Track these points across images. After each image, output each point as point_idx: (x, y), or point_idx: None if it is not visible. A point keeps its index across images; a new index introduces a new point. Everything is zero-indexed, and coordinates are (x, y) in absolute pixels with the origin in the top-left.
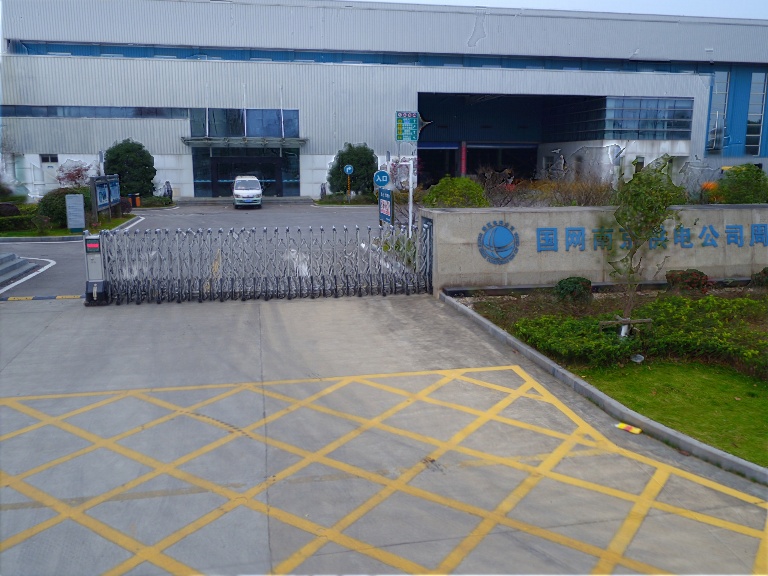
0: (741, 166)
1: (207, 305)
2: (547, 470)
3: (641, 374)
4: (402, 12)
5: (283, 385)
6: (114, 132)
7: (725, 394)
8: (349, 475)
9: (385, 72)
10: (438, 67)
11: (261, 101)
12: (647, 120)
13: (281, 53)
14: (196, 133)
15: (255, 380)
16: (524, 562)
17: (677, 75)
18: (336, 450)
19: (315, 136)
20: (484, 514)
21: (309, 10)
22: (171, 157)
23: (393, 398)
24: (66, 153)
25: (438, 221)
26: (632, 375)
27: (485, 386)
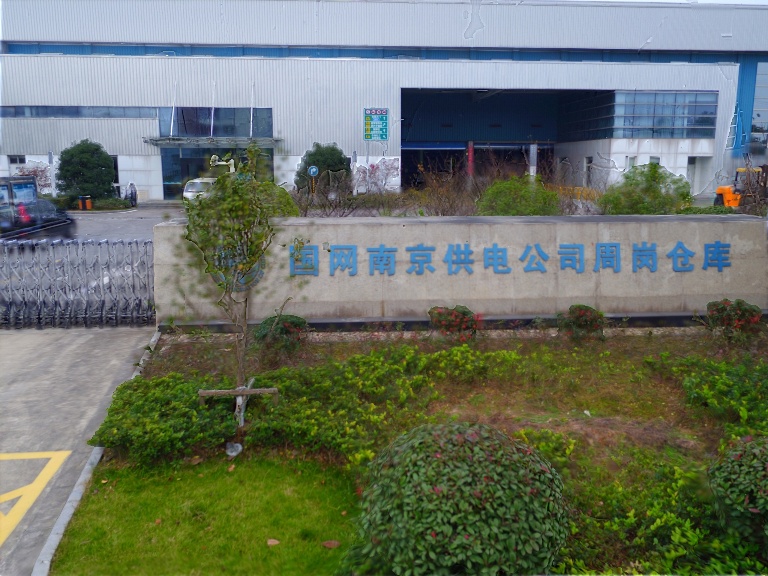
0: (641, 166)
1: None
2: None
3: (198, 480)
4: (402, 4)
5: None
6: (81, 132)
7: (266, 530)
8: None
9: (365, 67)
10: (423, 60)
11: (232, 99)
12: (663, 116)
13: (275, 50)
14: (165, 133)
15: None
16: None
17: (698, 66)
18: None
19: (290, 136)
20: None
21: (302, 4)
22: (139, 158)
23: None
24: (34, 154)
25: (155, 235)
26: (180, 482)
27: None
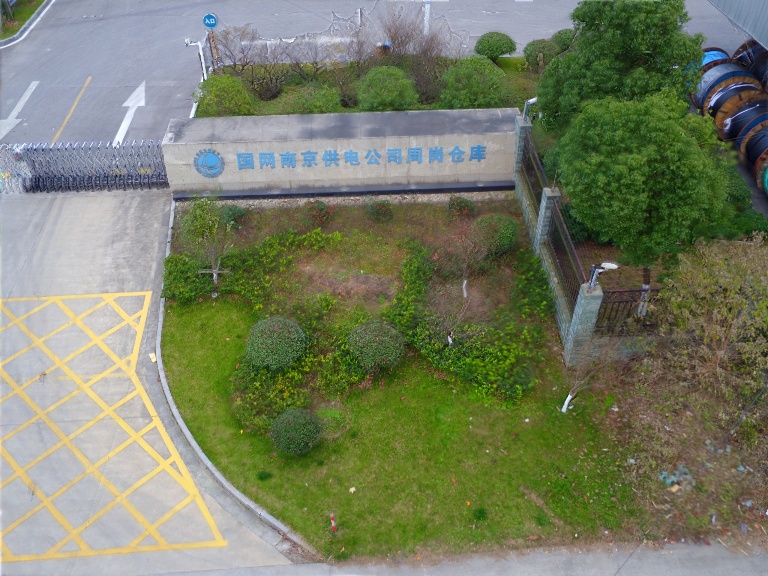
0: (470, 58)
1: (23, 198)
2: (88, 386)
3: (202, 311)
4: None
5: (16, 303)
6: None
7: (226, 334)
8: (3, 381)
9: None
10: None
11: None
12: None
13: None
14: None
15: (5, 296)
16: (32, 440)
17: None
18: (9, 362)
19: None
20: (39, 412)
21: None
22: None
23: (63, 320)
24: None
25: (163, 150)
26: (196, 312)
27: (117, 312)
